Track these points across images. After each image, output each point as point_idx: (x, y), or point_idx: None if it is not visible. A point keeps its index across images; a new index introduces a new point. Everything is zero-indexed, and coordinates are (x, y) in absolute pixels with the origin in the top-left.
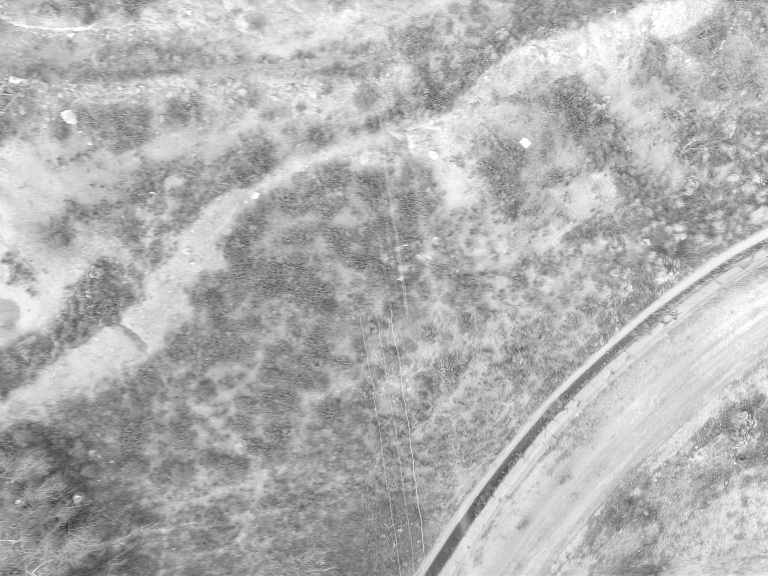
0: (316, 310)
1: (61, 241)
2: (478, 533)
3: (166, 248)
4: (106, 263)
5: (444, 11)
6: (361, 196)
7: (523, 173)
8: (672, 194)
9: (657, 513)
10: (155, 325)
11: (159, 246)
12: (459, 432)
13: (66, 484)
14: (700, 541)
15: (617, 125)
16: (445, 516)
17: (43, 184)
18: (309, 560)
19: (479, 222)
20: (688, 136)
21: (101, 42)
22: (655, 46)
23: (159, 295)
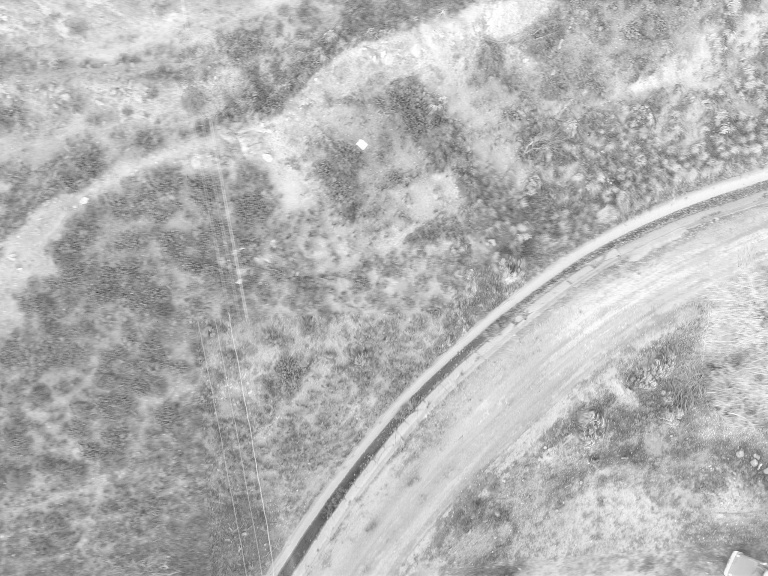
0: (151, 314)
1: None
2: (327, 536)
3: None
4: None
5: (273, 13)
6: (195, 200)
7: (361, 175)
8: (517, 194)
9: (509, 514)
10: None
11: None
12: (303, 435)
13: None
14: (556, 541)
15: (456, 126)
16: (293, 519)
17: None
18: (153, 565)
19: (317, 224)
20: (530, 136)
21: None
22: (490, 46)
23: None
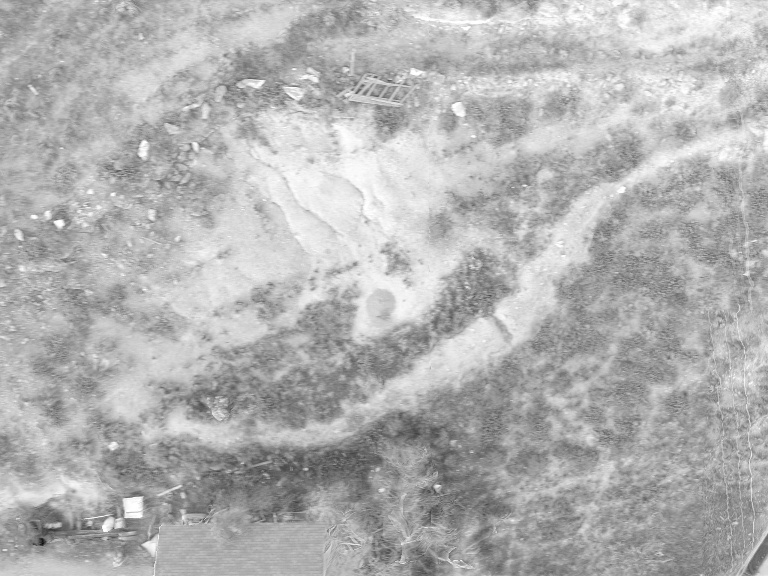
0: (670, 304)
1: (439, 232)
2: None
3: (541, 240)
4: (482, 255)
5: None
6: (716, 191)
7: None
8: None
9: None
10: (524, 317)
11: (534, 238)
12: None
13: None
14: None
15: None
16: None
17: (426, 175)
18: (648, 552)
19: None
20: None
21: (494, 35)
22: None
23: (533, 287)
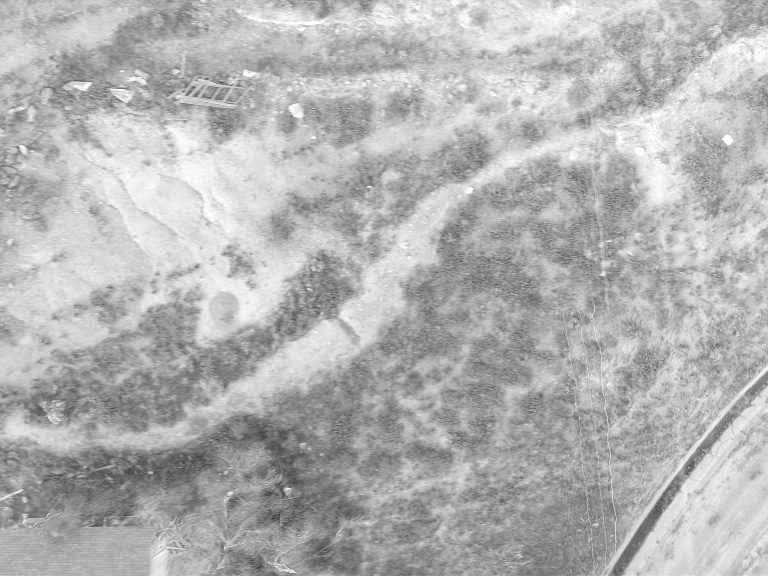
0: (522, 305)
1: (281, 234)
2: (668, 528)
3: (385, 242)
4: (325, 256)
5: (655, 8)
6: (568, 192)
7: (724, 170)
8: None
9: None
10: (370, 318)
11: (378, 240)
12: (655, 427)
13: (282, 476)
14: None
15: None
16: (637, 511)
17: (266, 177)
18: (507, 554)
19: (680, 218)
20: None
21: (330, 36)
22: None
23: (377, 289)
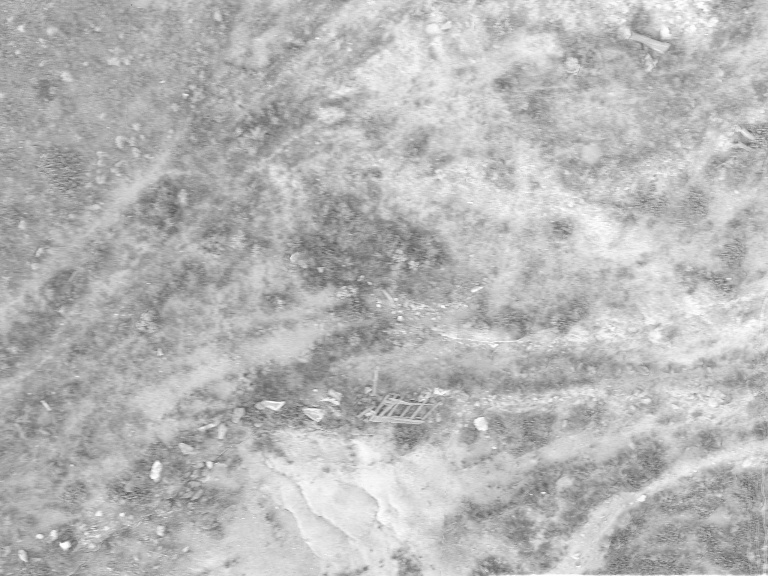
0: None
1: (453, 540)
2: None
3: (557, 552)
4: (495, 563)
5: None
6: (738, 497)
7: None
8: None
9: None
10: None
11: (550, 550)
12: None
13: None
14: None
15: None
16: None
17: (444, 485)
18: None
19: None
20: None
21: (522, 353)
22: None
23: None
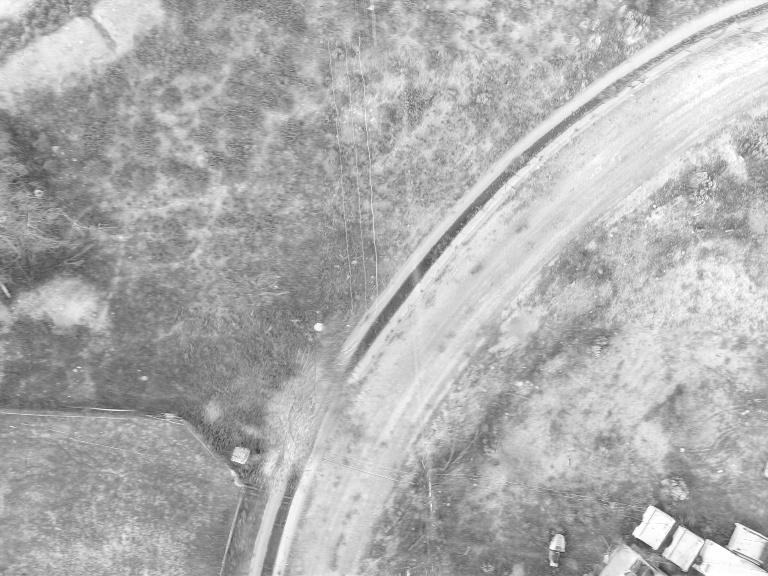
0: (285, 28)
1: None
2: (432, 277)
3: None
4: None
5: None
6: None
7: None
8: None
9: (611, 273)
10: (125, 22)
11: None
12: (419, 169)
13: (28, 170)
14: (653, 310)
15: None
16: (400, 256)
17: None
18: (263, 283)
19: None
20: None
21: None
22: None
23: None
